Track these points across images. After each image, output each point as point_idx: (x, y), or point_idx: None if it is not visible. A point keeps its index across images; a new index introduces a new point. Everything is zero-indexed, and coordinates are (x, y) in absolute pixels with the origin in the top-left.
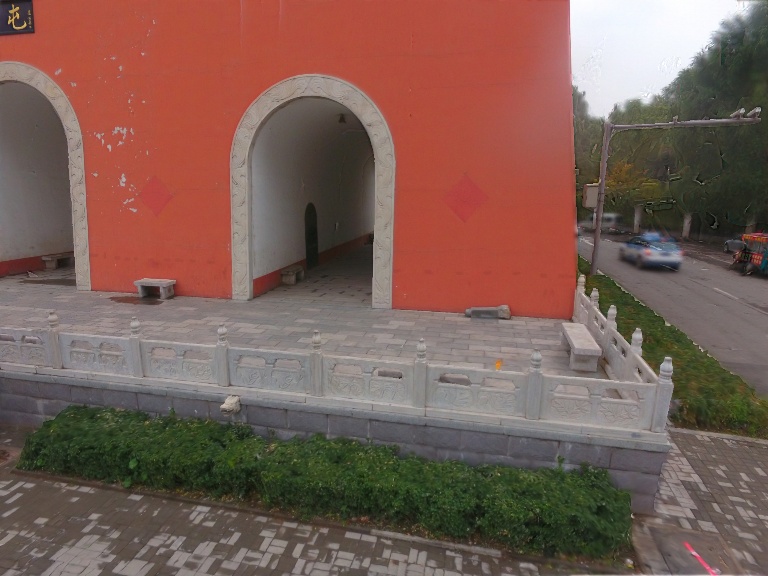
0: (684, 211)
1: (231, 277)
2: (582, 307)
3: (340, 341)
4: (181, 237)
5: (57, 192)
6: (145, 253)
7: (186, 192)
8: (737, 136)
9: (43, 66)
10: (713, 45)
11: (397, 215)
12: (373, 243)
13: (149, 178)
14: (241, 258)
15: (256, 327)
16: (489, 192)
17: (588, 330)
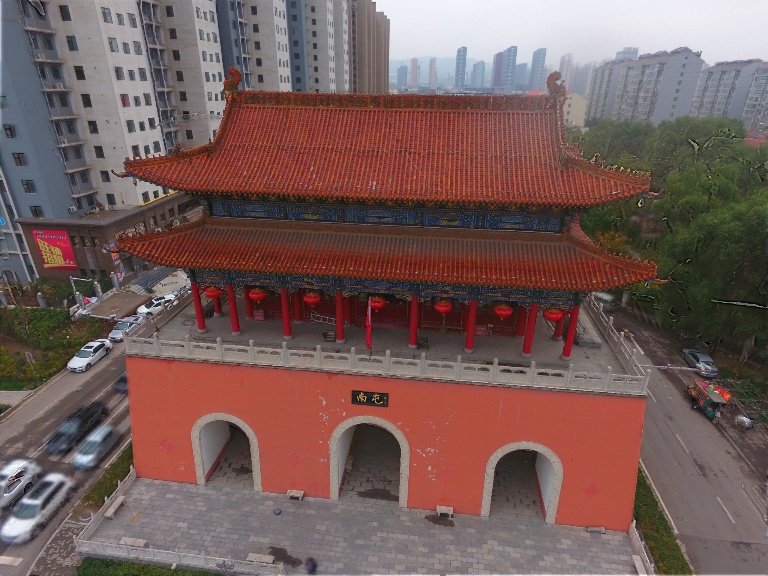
0: None
1: (481, 508)
2: None
3: (554, 563)
4: (457, 491)
5: (347, 429)
6: (438, 496)
7: (462, 476)
8: (699, 305)
9: (391, 420)
10: (692, 236)
11: (561, 493)
12: (549, 502)
13: (444, 469)
14: (487, 502)
15: (515, 551)
16: (601, 489)
17: (642, 562)
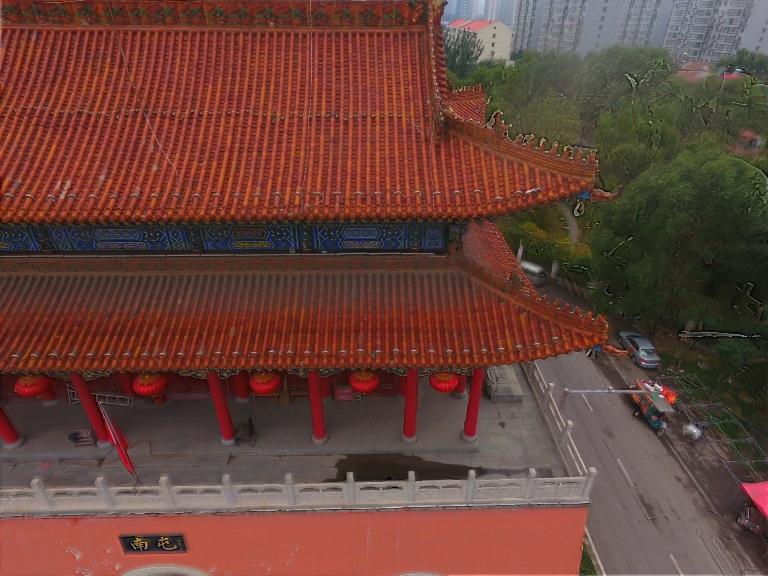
0: (591, 278)
1: None
2: None
3: None
4: None
5: None
6: None
7: None
8: (640, 286)
9: (197, 568)
10: (632, 201)
11: None
12: None
13: None
14: None
15: None
16: None
17: None
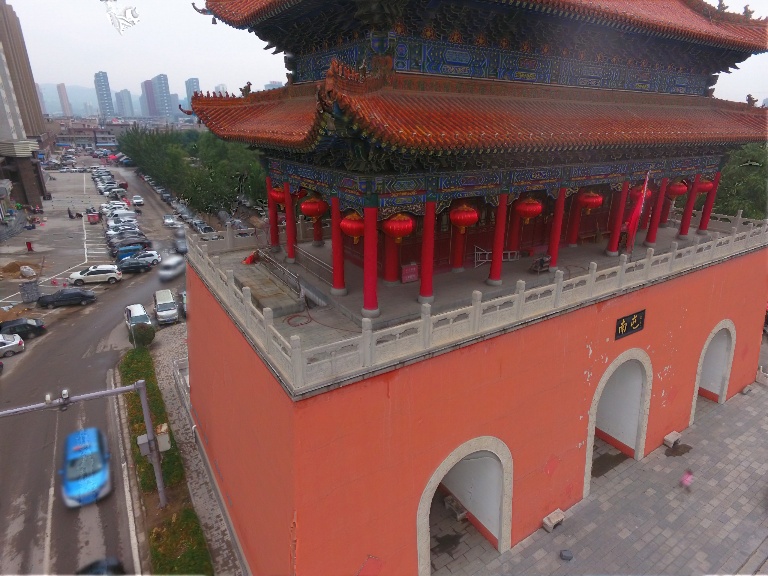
0: None
1: None
2: (767, 378)
3: None
4: (677, 409)
5: None
6: None
7: None
8: None
9: None
10: None
11: None
12: None
13: None
14: None
15: (747, 436)
16: None
17: None
